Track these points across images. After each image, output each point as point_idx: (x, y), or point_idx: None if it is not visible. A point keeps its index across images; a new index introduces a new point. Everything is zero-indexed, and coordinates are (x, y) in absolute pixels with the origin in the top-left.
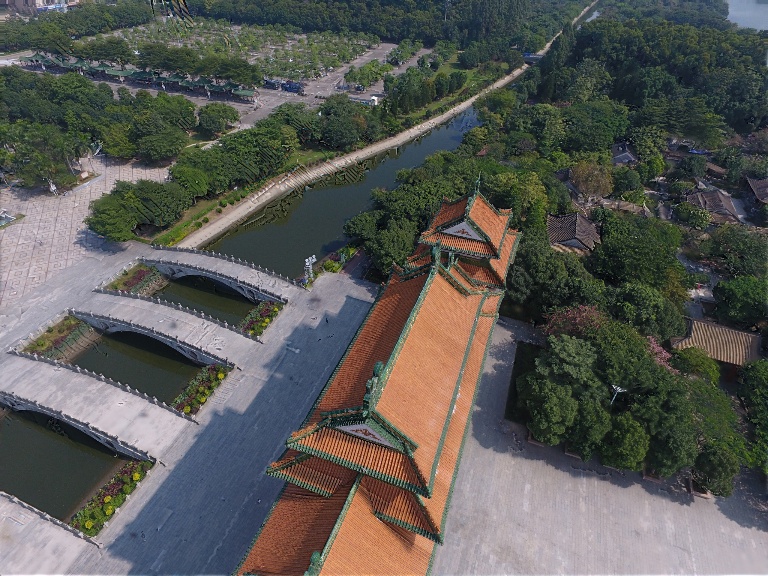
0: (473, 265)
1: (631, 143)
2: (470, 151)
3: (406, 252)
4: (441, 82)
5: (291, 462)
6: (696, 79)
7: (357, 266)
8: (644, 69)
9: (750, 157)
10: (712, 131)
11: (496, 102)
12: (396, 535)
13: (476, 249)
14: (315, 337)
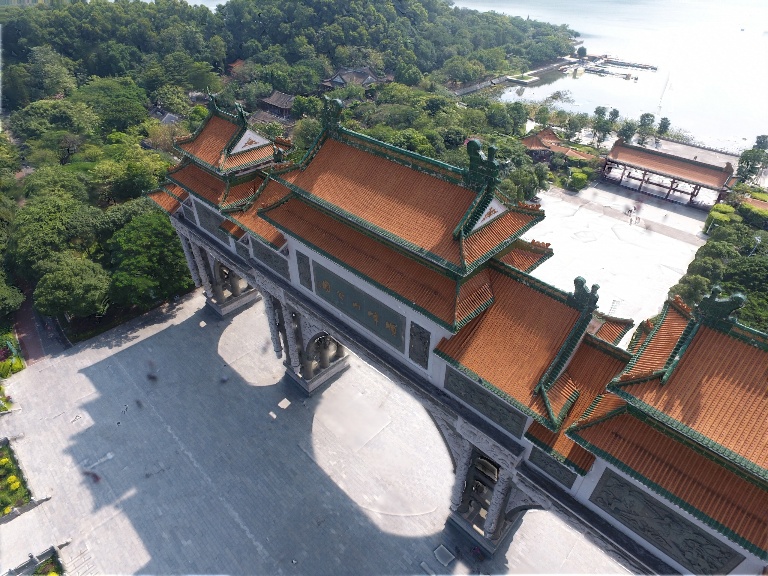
0: None
1: (162, 106)
2: (10, 174)
3: (103, 276)
4: None
5: None
6: (150, 45)
7: (42, 343)
8: (103, 44)
9: (251, 84)
10: (209, 76)
11: None
12: None
13: (271, 152)
14: (108, 427)
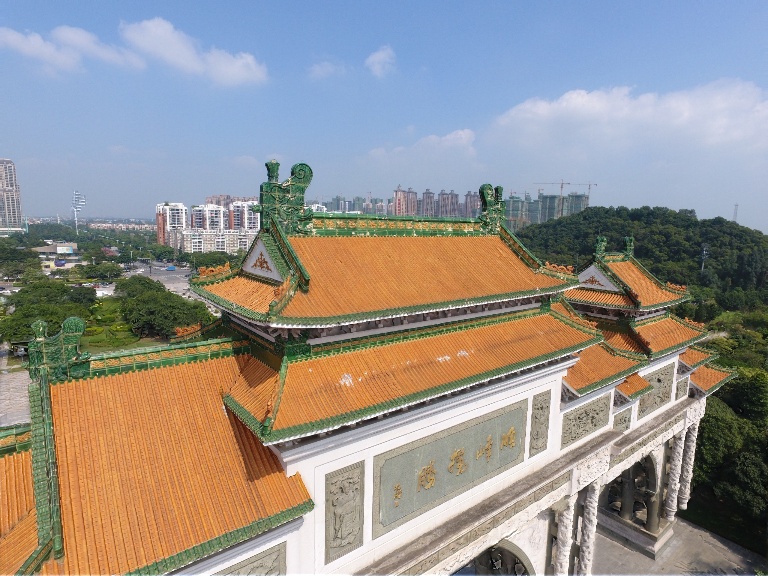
0: (607, 330)
1: None
2: None
3: None
4: (683, 307)
5: (196, 335)
6: None
7: None
8: None
9: None
10: None
11: (757, 323)
12: (235, 449)
13: (608, 301)
14: None
